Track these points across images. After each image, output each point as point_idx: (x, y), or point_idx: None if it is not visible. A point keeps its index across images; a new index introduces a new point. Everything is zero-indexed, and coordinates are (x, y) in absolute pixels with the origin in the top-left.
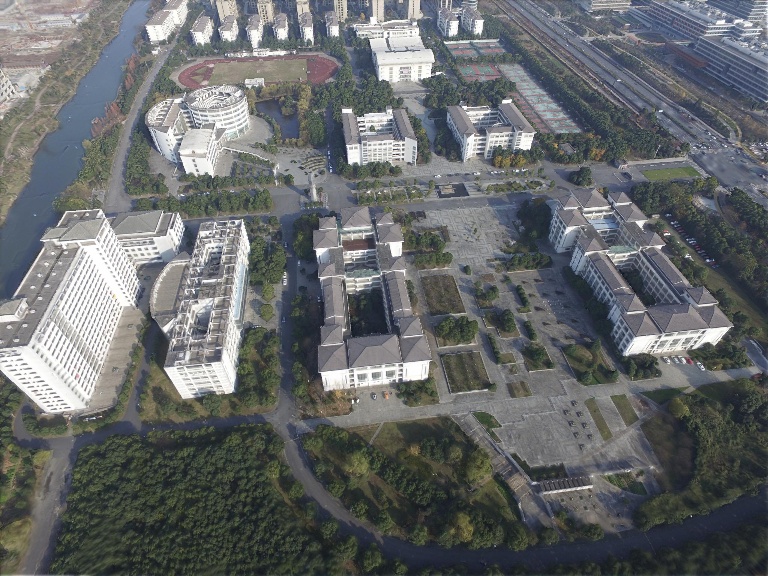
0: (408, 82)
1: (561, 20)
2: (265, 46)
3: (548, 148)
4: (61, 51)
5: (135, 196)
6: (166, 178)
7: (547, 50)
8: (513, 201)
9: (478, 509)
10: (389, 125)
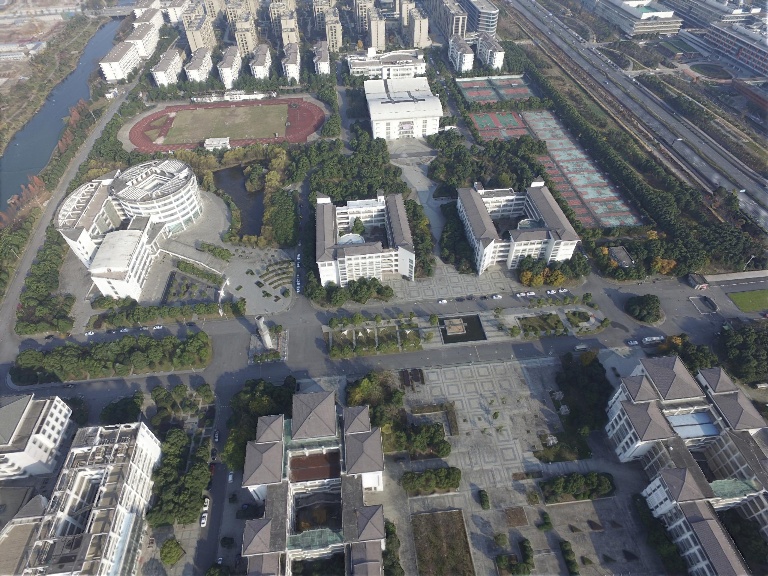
0: (410, 139)
1: (597, 47)
2: (240, 86)
3: (595, 254)
4: None
5: (27, 334)
6: (77, 301)
7: (583, 90)
8: (549, 350)
9: None
10: (380, 215)
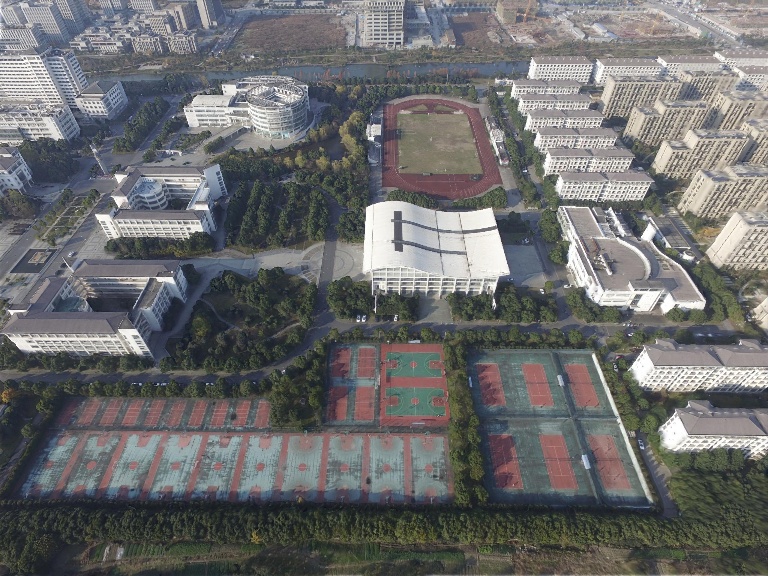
0: None
1: None
2: None
3: None
4: (500, 45)
5: None
6: None
7: None
8: None
9: None
10: None
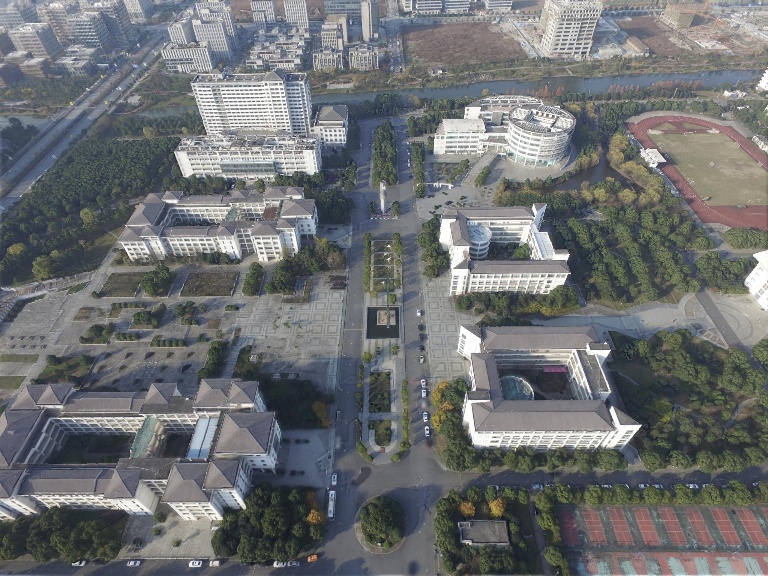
0: None
1: None
2: None
3: None
4: (694, 52)
5: None
6: None
7: None
8: (344, 388)
9: (20, 259)
10: None
